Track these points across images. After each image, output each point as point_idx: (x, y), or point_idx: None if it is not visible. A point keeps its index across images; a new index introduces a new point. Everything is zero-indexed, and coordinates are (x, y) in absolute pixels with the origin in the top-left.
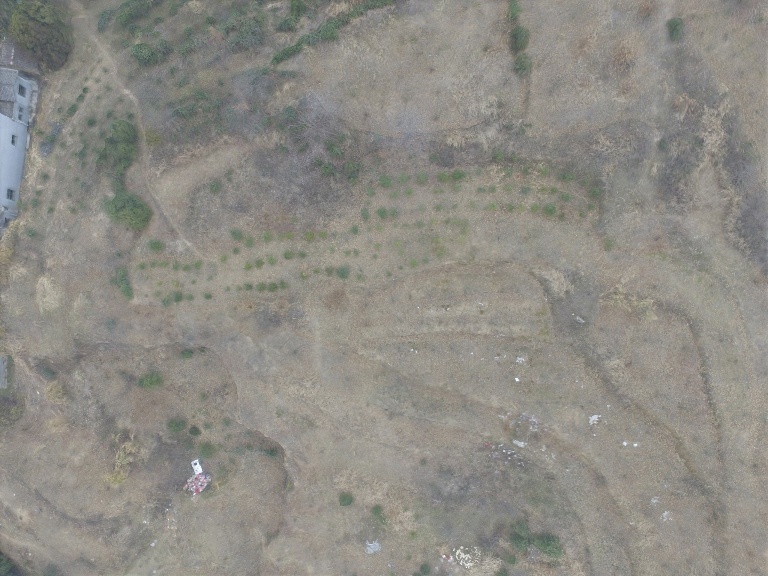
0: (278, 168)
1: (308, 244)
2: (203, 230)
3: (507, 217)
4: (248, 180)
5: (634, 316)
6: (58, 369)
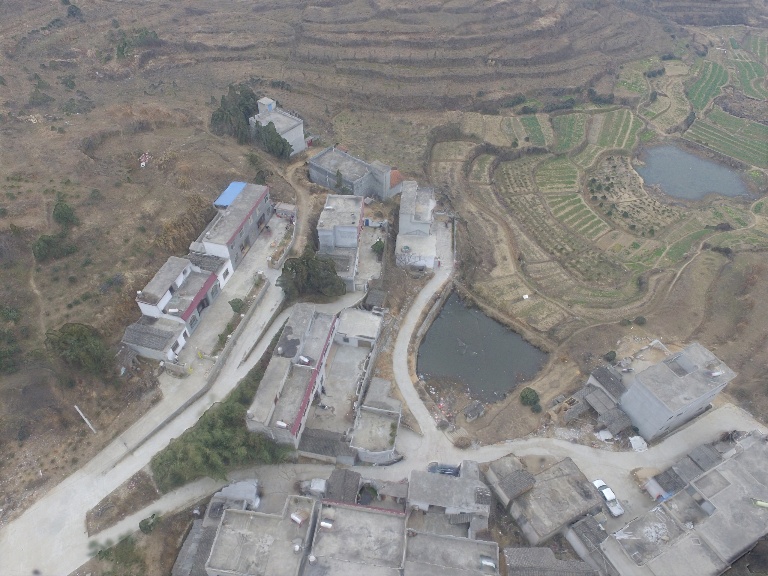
0: None
1: None
2: None
3: None
4: None
5: None
6: None
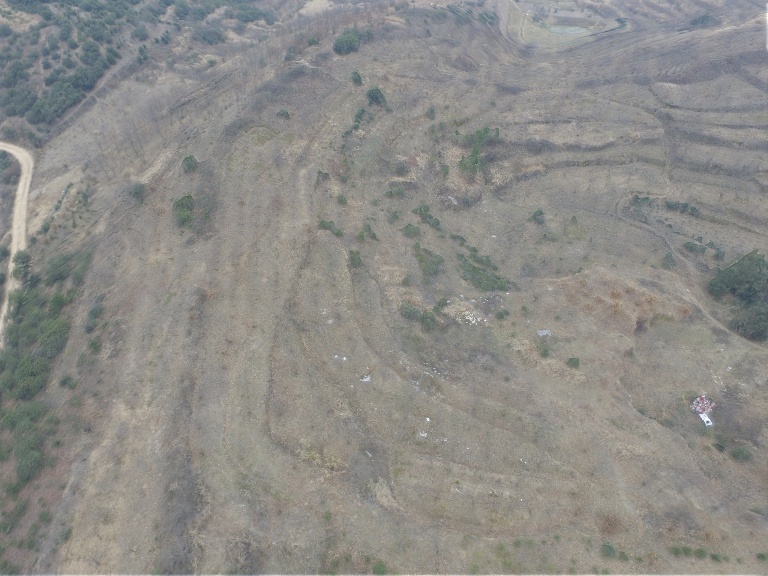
0: None
1: None
2: None
3: (425, 575)
4: None
5: (318, 448)
6: None
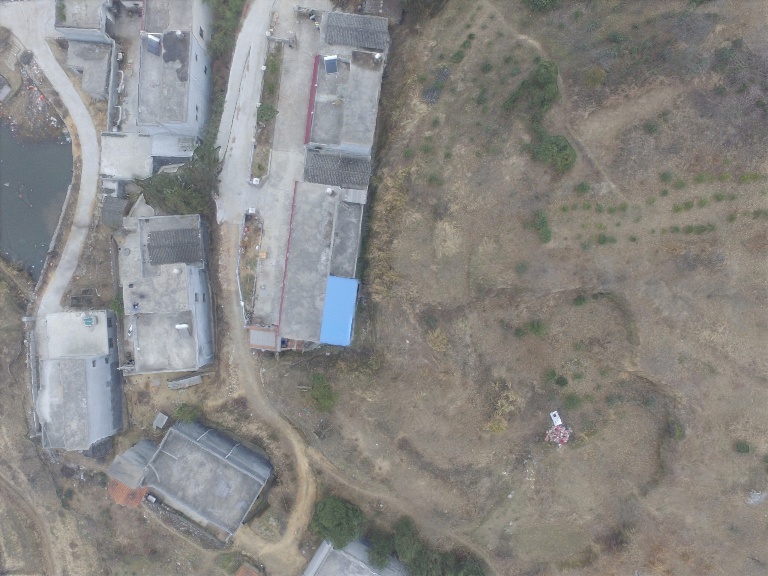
0: (719, 108)
1: (738, 186)
2: (631, 172)
3: None
4: (686, 121)
5: None
6: (441, 316)
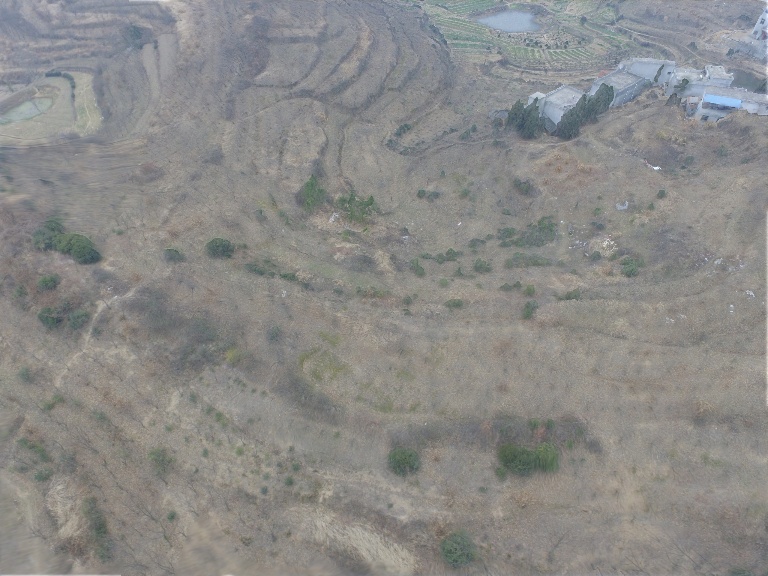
0: None
1: None
2: None
3: None
4: None
5: None
6: None
